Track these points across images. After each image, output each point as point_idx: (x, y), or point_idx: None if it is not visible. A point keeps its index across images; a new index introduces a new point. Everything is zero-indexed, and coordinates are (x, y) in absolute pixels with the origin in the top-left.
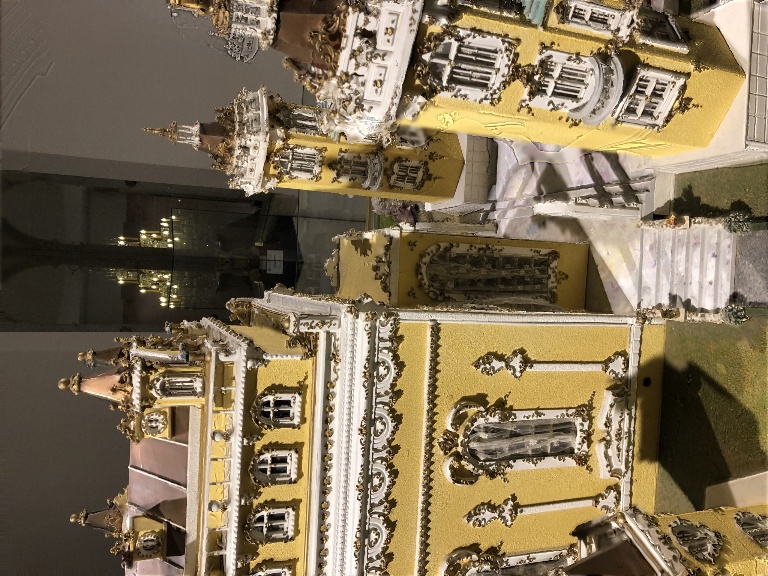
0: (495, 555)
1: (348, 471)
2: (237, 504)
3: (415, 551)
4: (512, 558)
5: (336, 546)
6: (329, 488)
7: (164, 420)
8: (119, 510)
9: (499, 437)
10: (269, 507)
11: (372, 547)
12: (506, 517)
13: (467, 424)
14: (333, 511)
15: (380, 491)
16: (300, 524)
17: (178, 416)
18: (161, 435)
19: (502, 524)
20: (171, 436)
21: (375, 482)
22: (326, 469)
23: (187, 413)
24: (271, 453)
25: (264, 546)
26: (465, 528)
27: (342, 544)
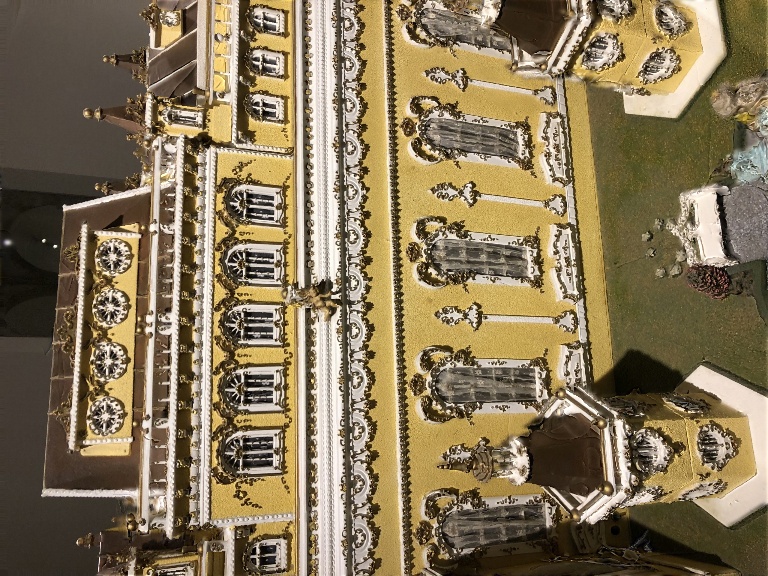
0: (453, 109)
1: (324, 11)
2: (237, 32)
3: (384, 87)
4: (468, 116)
5: (318, 63)
6: (310, 27)
7: (177, 17)
8: (138, 153)
9: (445, 20)
10: (263, 48)
11: (348, 71)
12: (458, 82)
13: (418, 2)
14: (314, 42)
15: (351, 32)
16: (289, 69)
17: (188, 16)
18: (175, 29)
19: (456, 85)
20: (183, 33)
21: (346, 25)
22: (307, 12)
23: (196, 7)
24: (263, 9)
25: (261, 79)
26: (425, 83)
27: (323, 62)
